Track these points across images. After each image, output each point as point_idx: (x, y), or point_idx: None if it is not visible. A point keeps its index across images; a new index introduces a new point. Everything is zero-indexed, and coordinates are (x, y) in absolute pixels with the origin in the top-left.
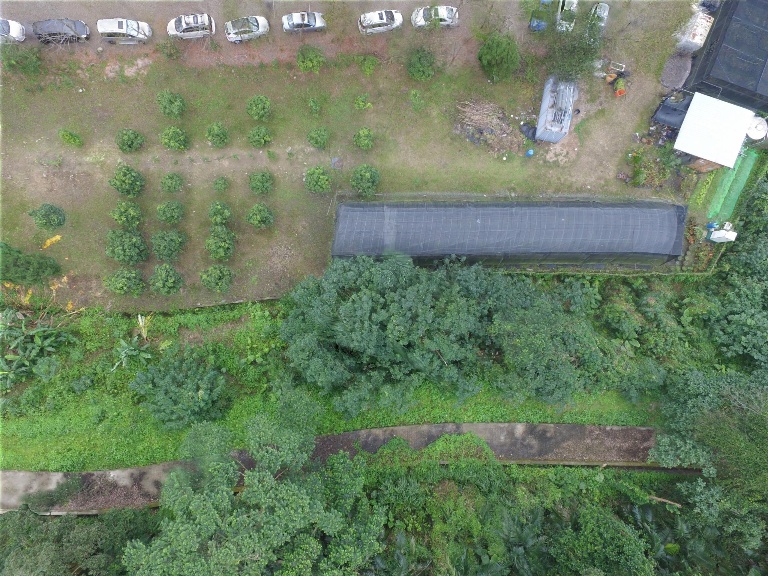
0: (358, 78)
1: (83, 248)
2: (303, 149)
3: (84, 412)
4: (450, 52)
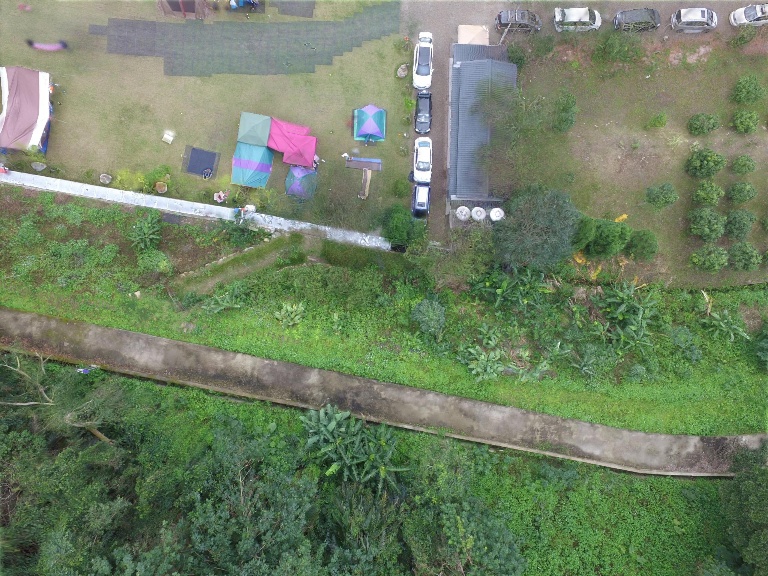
0: None
1: (648, 227)
2: None
3: (711, 380)
4: None
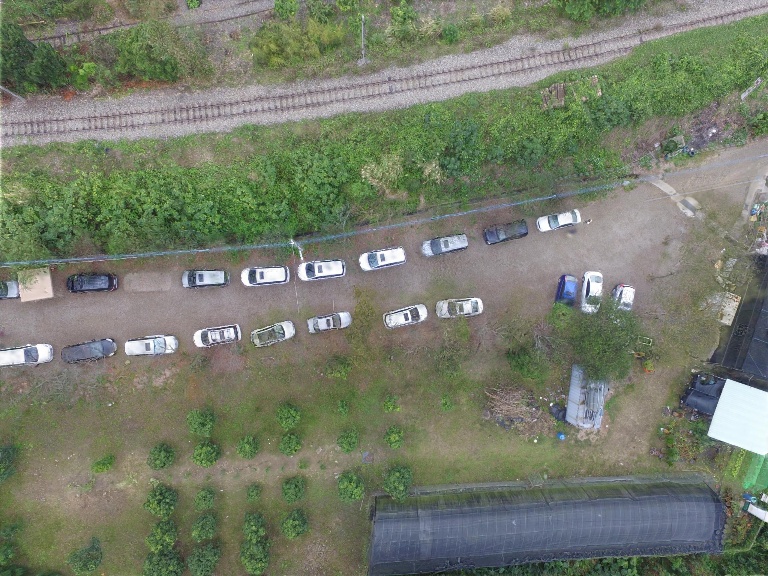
0: (385, 370)
1: (119, 562)
2: (333, 448)
3: None
4: (476, 338)
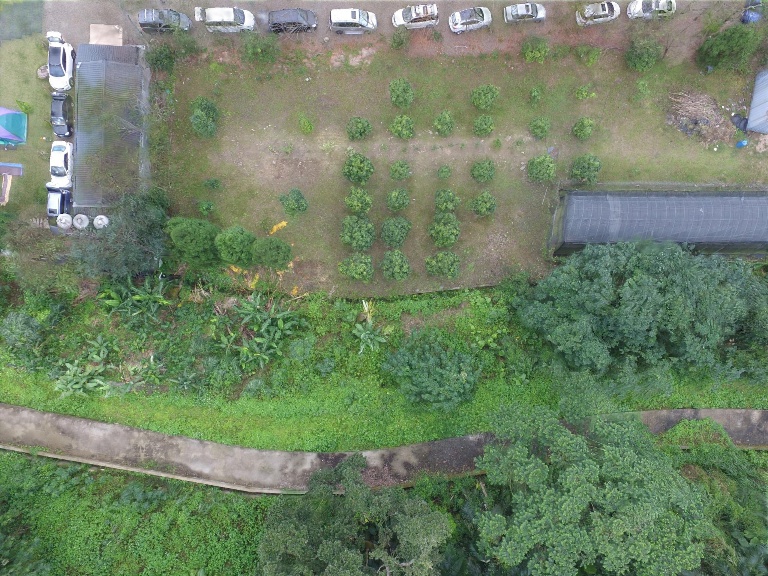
0: (574, 69)
1: (308, 234)
2: (521, 138)
3: (334, 394)
4: (663, 44)
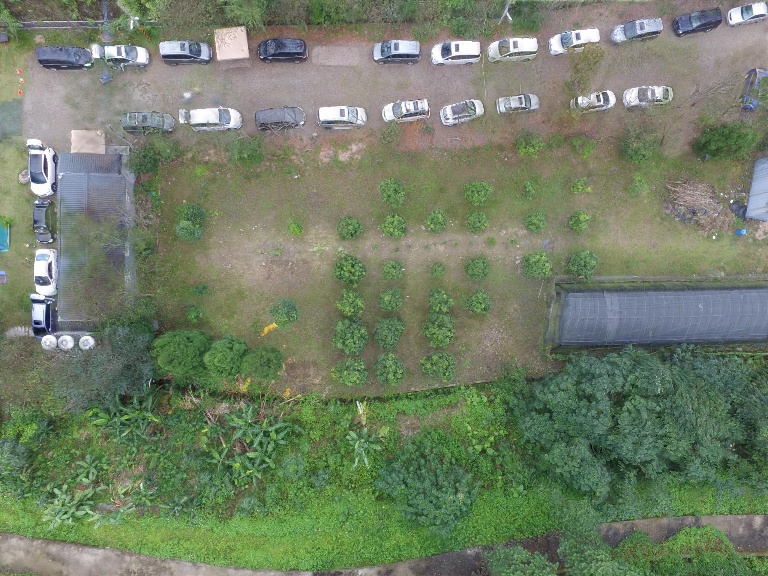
0: (569, 159)
1: (300, 335)
2: (516, 232)
3: (329, 510)
4: (660, 131)
